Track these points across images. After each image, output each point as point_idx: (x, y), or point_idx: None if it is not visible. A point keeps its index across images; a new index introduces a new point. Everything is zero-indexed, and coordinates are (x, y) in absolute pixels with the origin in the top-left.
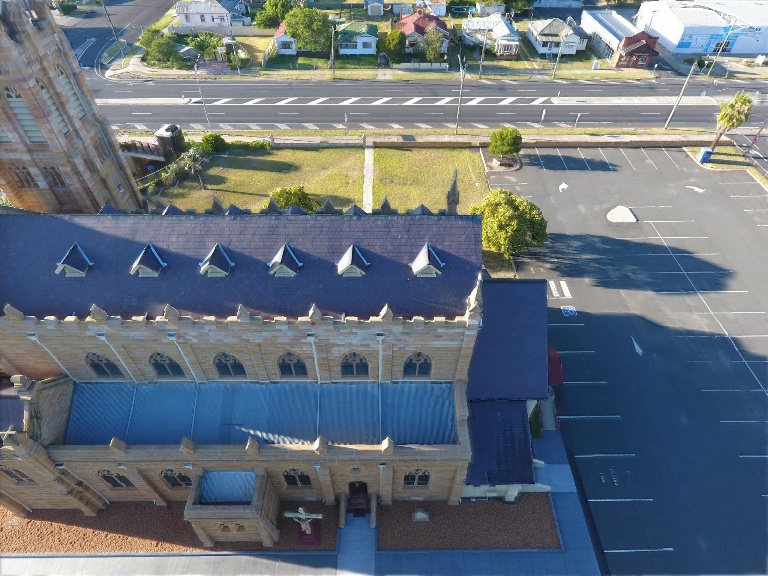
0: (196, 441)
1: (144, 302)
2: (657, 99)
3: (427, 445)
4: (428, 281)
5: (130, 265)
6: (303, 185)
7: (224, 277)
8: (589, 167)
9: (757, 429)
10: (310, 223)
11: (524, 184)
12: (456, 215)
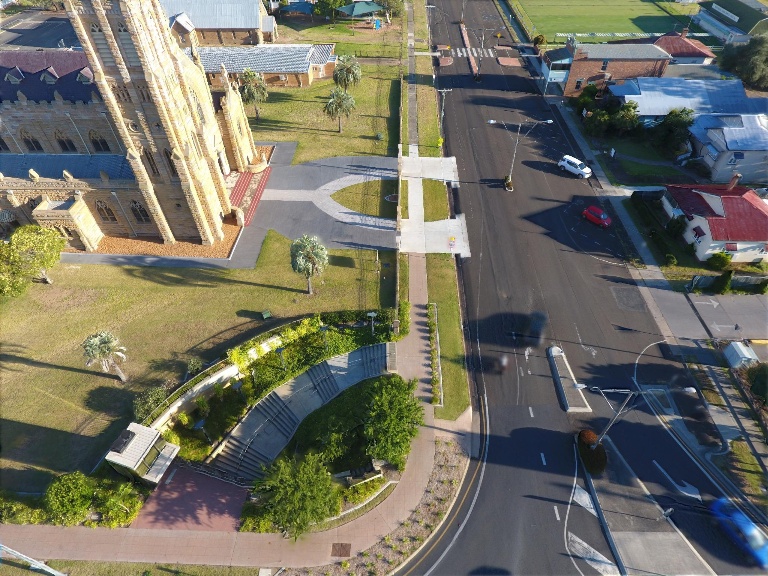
0: None
1: None
2: None
3: None
4: None
5: None
6: None
7: None
8: None
9: None
10: None
11: None
12: None
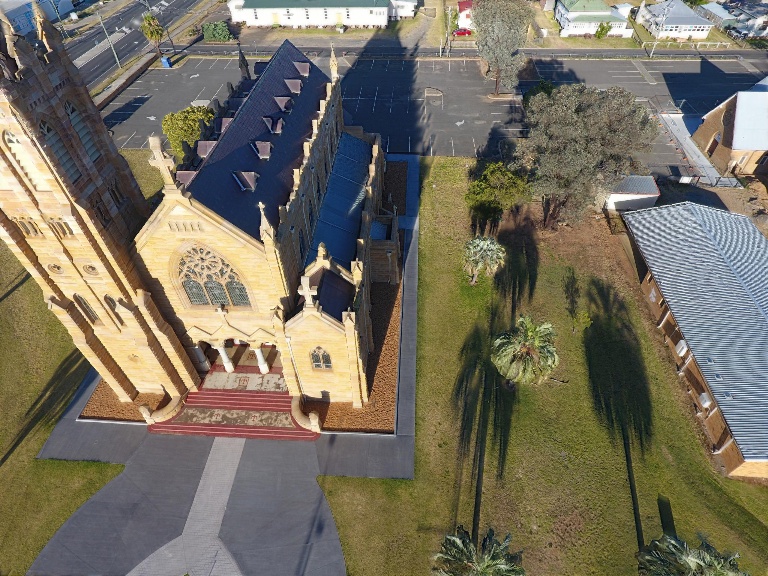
0: (354, 231)
1: (285, 171)
2: (79, 60)
3: (375, 143)
4: (310, 78)
5: (259, 159)
6: (15, 263)
7: (283, 131)
8: (138, 104)
9: (361, 106)
10: (266, 80)
11: (135, 133)
12: (283, 44)
